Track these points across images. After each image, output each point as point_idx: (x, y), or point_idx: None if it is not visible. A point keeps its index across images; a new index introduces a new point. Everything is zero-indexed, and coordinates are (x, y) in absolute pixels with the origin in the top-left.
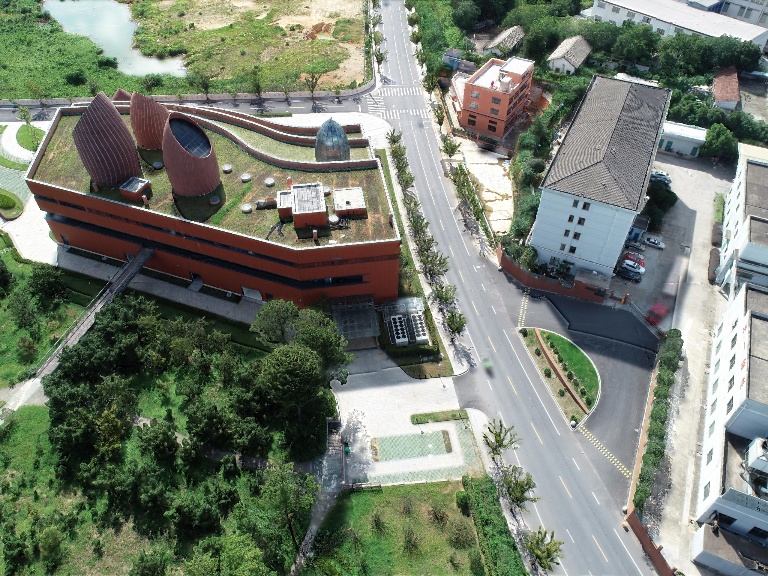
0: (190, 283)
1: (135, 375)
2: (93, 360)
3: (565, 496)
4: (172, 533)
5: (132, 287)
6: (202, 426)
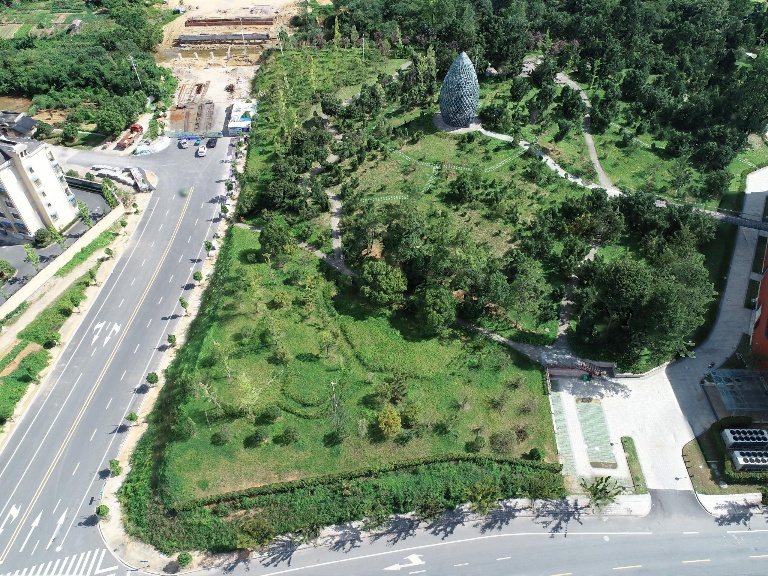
0: (759, 273)
1: (637, 242)
2: (636, 206)
3: (547, 570)
4: (507, 266)
5: (739, 237)
6: (584, 264)
